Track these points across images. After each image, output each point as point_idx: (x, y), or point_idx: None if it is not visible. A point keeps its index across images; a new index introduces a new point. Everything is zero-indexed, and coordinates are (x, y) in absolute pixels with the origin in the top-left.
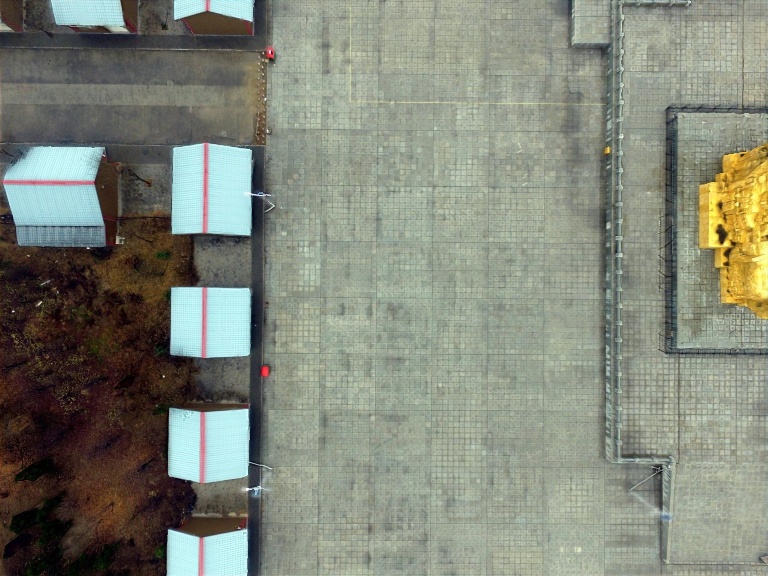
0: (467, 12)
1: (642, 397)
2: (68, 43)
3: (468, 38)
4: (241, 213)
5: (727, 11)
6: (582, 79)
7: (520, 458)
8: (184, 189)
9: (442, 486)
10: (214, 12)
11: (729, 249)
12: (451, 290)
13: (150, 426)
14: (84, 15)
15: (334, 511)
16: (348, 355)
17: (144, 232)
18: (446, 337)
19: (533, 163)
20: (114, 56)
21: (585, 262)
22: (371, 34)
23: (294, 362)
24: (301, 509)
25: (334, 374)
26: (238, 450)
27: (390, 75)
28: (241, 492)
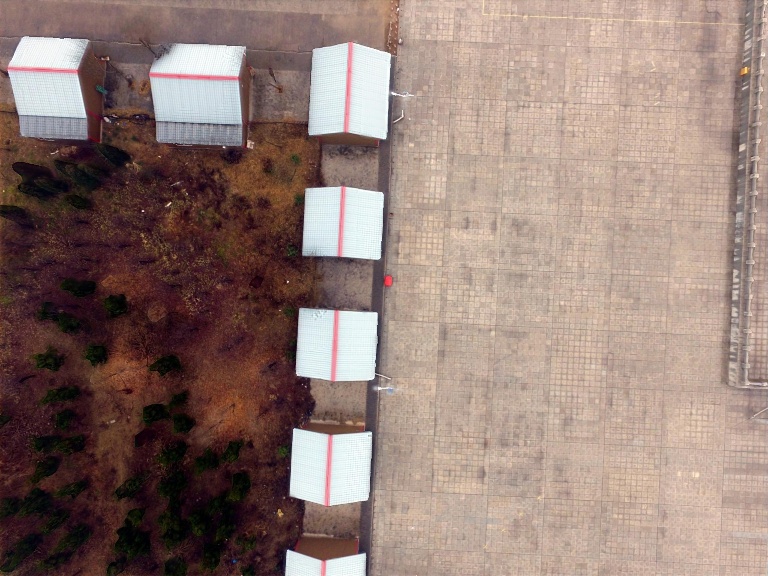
0: None
1: None
2: None
3: None
4: (379, 116)
5: None
6: None
7: (640, 380)
8: (323, 90)
9: (560, 404)
10: None
11: None
12: (577, 208)
13: (273, 330)
14: None
15: (451, 424)
16: (471, 269)
17: (274, 137)
18: (570, 255)
19: (666, 82)
20: None
21: (715, 185)
22: None
23: (416, 274)
24: (418, 421)
25: (456, 288)
26: (367, 352)
27: None
28: (359, 400)
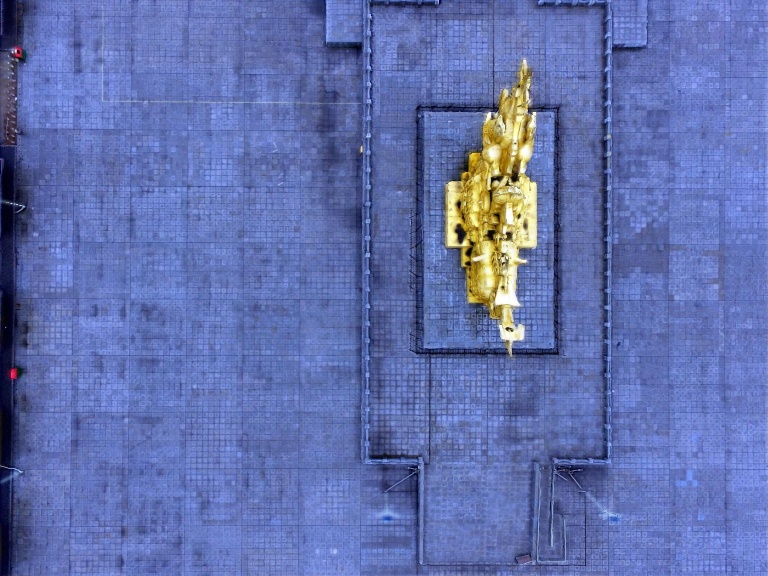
0: (221, 11)
1: (393, 398)
2: None
3: (222, 37)
4: None
5: (477, 9)
6: (338, 78)
7: (276, 460)
8: None
9: (197, 488)
10: None
11: (470, 249)
12: (206, 291)
13: None
14: None
15: (87, 514)
16: (101, 357)
17: None
18: (201, 338)
19: (289, 163)
20: None
21: (341, 262)
22: (123, 33)
23: (46, 364)
24: (53, 513)
25: (87, 376)
26: None
27: (143, 74)
28: None
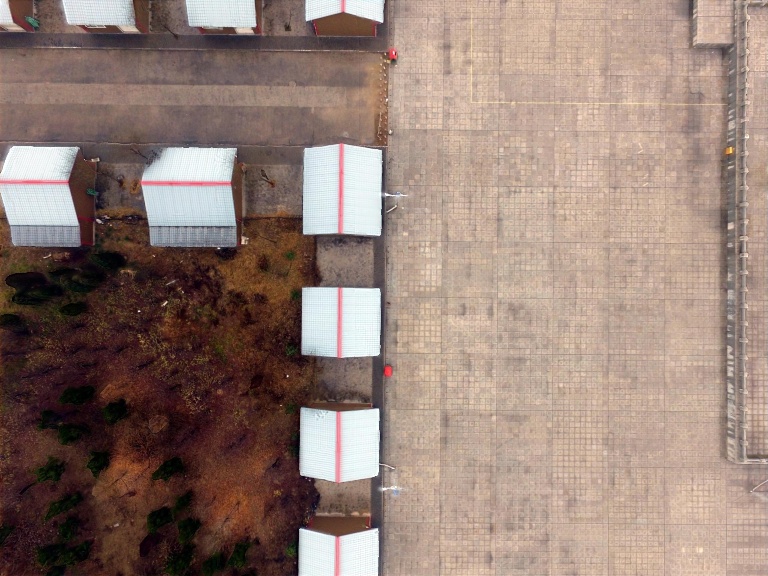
0: (588, 12)
1: (766, 398)
2: (193, 44)
3: (589, 38)
4: (372, 213)
5: None
6: (703, 79)
7: (641, 458)
8: (316, 190)
9: (563, 486)
10: (349, 13)
11: None
12: (572, 290)
13: (275, 425)
14: (218, 17)
15: (456, 511)
16: (469, 355)
17: (268, 232)
18: (567, 337)
19: (654, 163)
20: (237, 57)
21: (706, 262)
22: (492, 35)
23: (415, 362)
24: (423, 509)
25: (455, 374)
26: (370, 450)
27: (511, 76)
28: (364, 491)
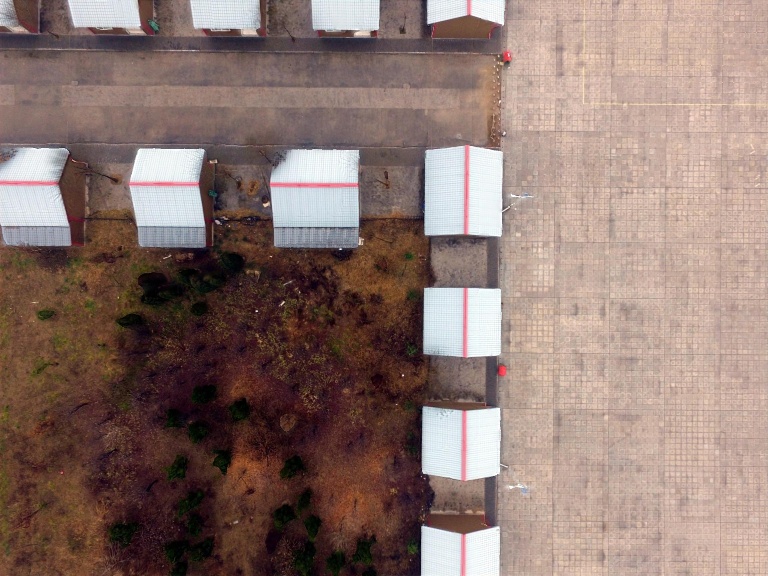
0: (700, 14)
1: None
2: (309, 47)
3: (701, 40)
4: (494, 214)
5: None
6: None
7: (753, 458)
8: (439, 191)
9: (675, 485)
10: (474, 16)
11: None
12: (684, 291)
13: (390, 424)
14: (342, 20)
15: (568, 509)
16: (582, 355)
17: (383, 233)
18: (679, 337)
19: (766, 164)
20: (352, 60)
21: None
22: (605, 36)
23: (528, 362)
24: (536, 507)
25: (568, 374)
26: (492, 448)
27: (623, 77)
28: (478, 490)
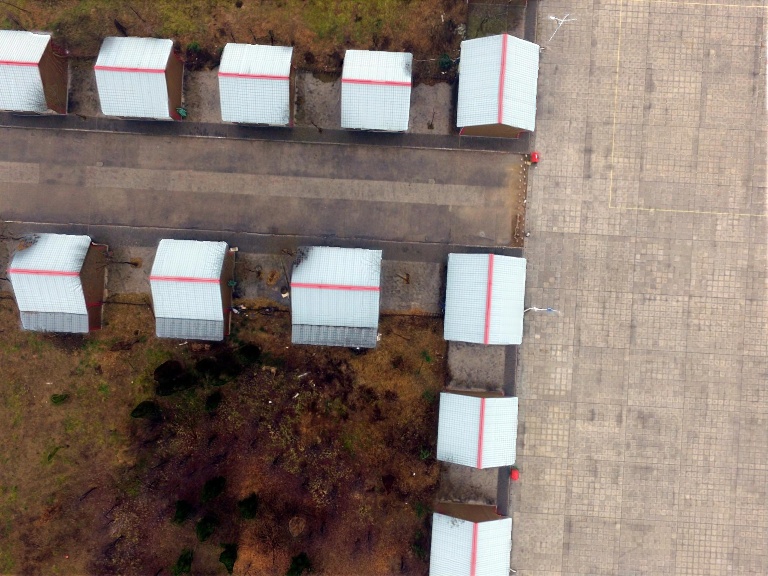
0: (732, 122)
1: None
2: (335, 139)
3: (732, 148)
4: (515, 322)
5: None
6: None
7: (766, 575)
8: (461, 296)
9: None
10: (505, 124)
11: None
12: (703, 401)
13: (399, 523)
14: (371, 119)
15: None
16: (596, 461)
17: (401, 329)
18: (696, 448)
19: None
20: (378, 153)
21: None
22: (634, 141)
23: (541, 465)
24: None
25: (581, 480)
26: (502, 559)
27: (651, 182)
28: None
